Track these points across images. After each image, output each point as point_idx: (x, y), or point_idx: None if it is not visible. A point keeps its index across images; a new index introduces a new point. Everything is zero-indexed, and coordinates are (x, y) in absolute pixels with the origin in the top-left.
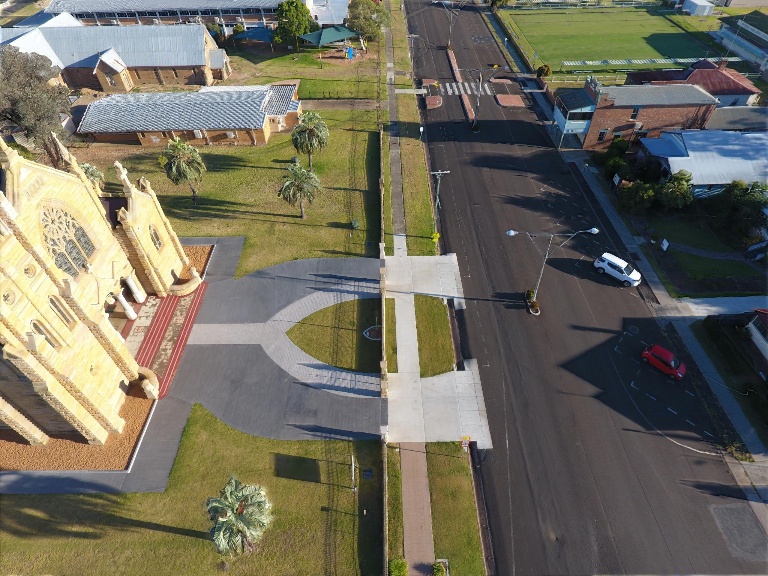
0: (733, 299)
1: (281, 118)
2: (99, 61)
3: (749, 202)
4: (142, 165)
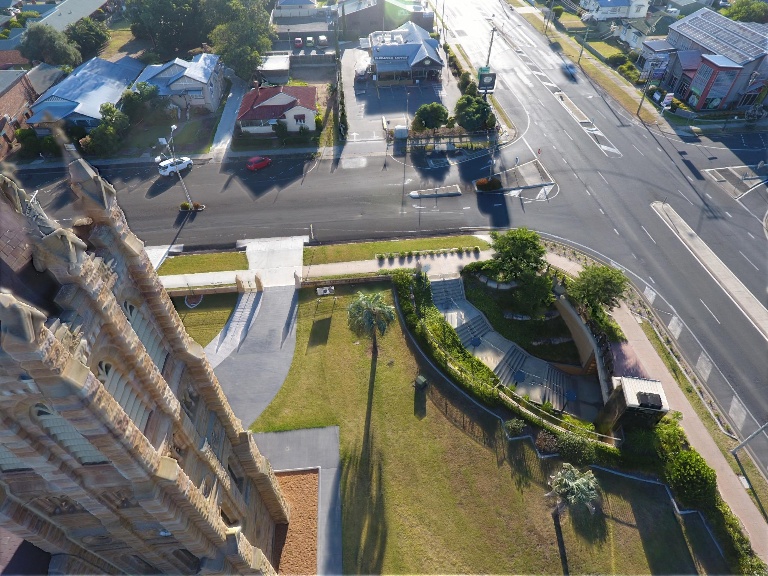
0: (217, 134)
1: None
2: None
3: (150, 94)
4: None
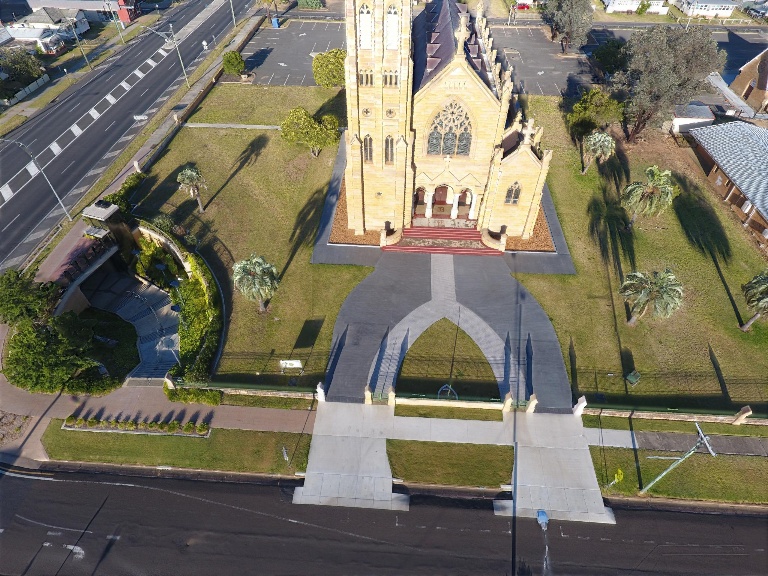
0: None
1: None
2: None
3: None
4: None
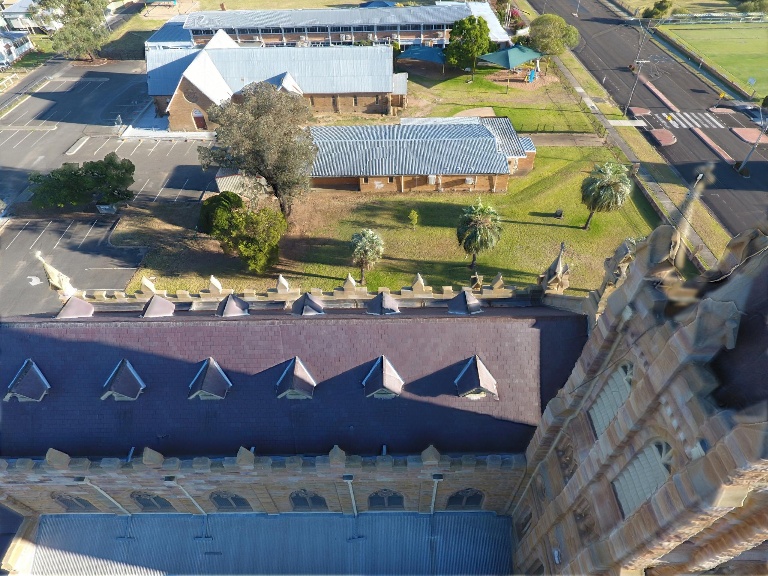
0: None
1: (516, 159)
2: (280, 88)
3: None
4: (378, 218)
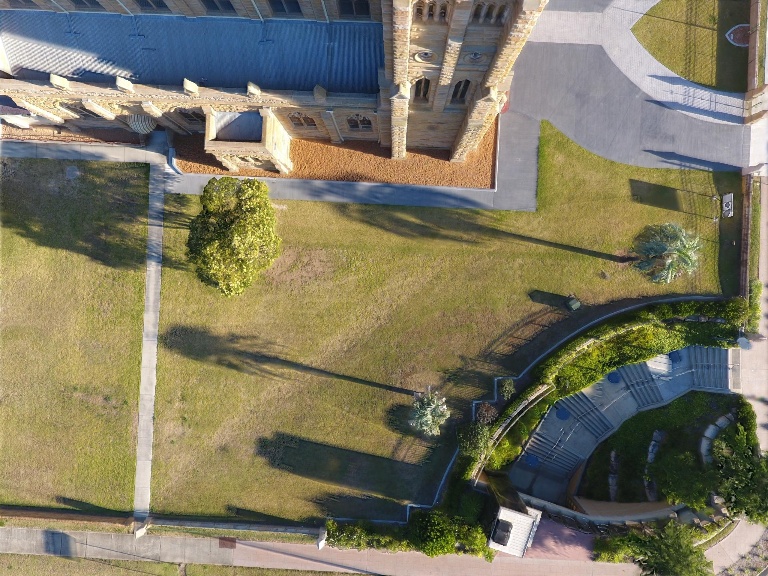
0: None
1: None
2: None
3: None
4: None
